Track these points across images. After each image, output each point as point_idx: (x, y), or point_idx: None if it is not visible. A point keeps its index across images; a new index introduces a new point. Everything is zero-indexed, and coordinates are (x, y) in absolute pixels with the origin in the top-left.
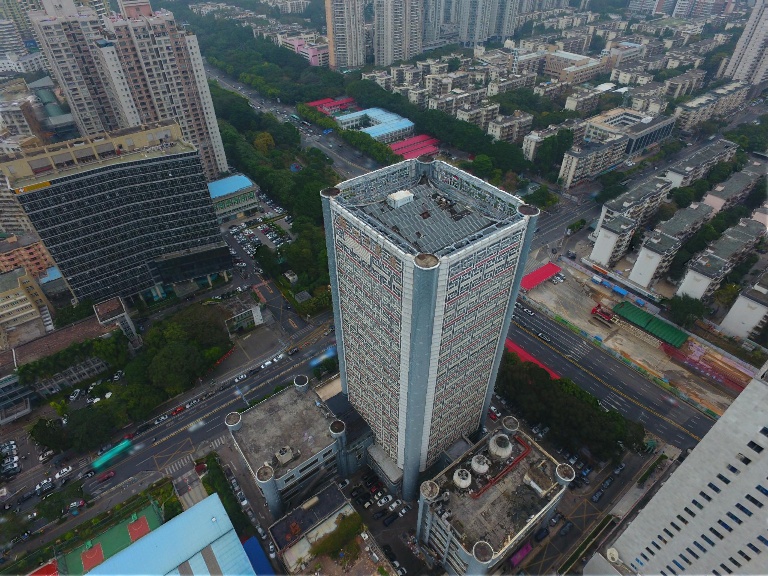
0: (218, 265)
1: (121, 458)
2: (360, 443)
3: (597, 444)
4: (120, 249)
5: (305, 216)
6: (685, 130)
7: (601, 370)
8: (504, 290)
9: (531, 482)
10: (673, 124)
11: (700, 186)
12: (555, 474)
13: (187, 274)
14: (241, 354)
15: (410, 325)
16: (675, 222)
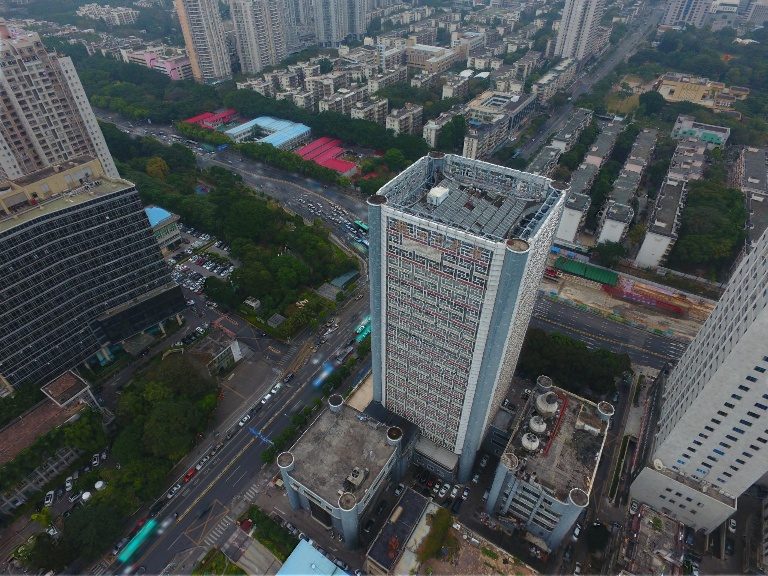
0: (171, 308)
1: (145, 548)
2: (411, 443)
3: (600, 380)
4: (57, 315)
5: (241, 238)
6: (542, 104)
7: (567, 319)
8: (544, 261)
9: (585, 426)
10: (535, 100)
11: (579, 149)
12: (597, 413)
13: (137, 326)
14: (233, 396)
15: (492, 310)
16: (576, 182)
